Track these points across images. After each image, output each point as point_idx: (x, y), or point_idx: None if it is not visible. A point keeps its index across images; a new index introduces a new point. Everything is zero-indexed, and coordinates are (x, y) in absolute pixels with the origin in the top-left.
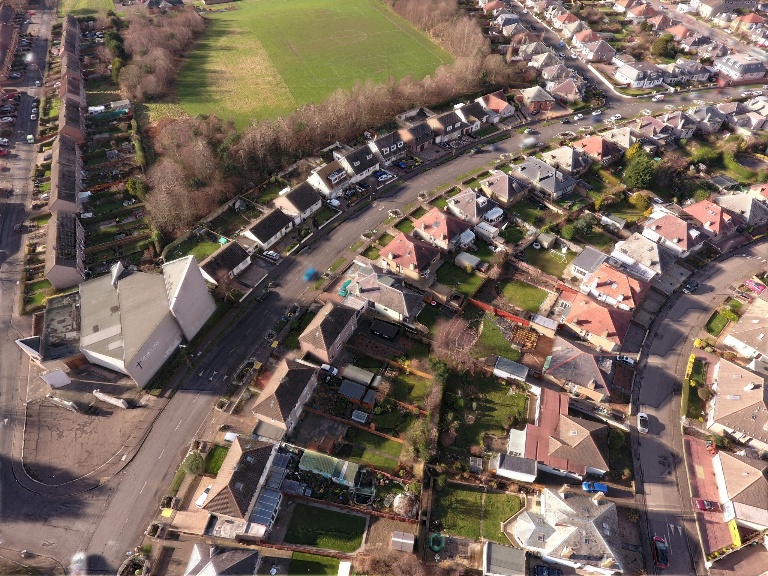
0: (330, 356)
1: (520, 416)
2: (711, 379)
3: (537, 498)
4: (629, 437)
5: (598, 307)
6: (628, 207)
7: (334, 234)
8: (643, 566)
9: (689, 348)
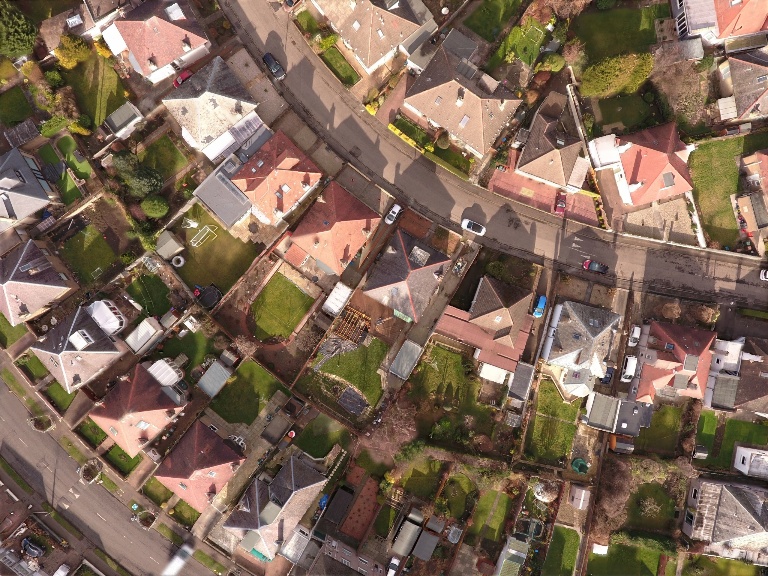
0: (379, 572)
1: (470, 367)
2: (422, 120)
3: (545, 364)
4: (488, 249)
5: (331, 233)
6: (80, 74)
7: (139, 570)
8: (605, 287)
9: (376, 123)
